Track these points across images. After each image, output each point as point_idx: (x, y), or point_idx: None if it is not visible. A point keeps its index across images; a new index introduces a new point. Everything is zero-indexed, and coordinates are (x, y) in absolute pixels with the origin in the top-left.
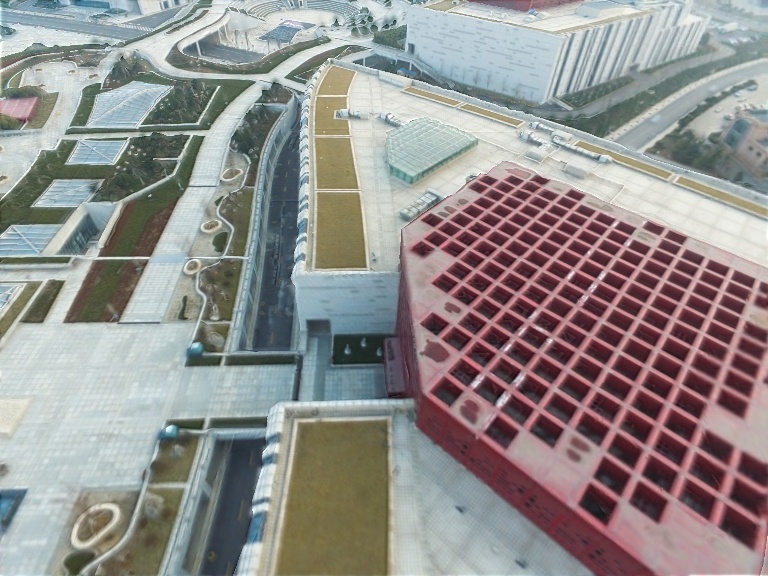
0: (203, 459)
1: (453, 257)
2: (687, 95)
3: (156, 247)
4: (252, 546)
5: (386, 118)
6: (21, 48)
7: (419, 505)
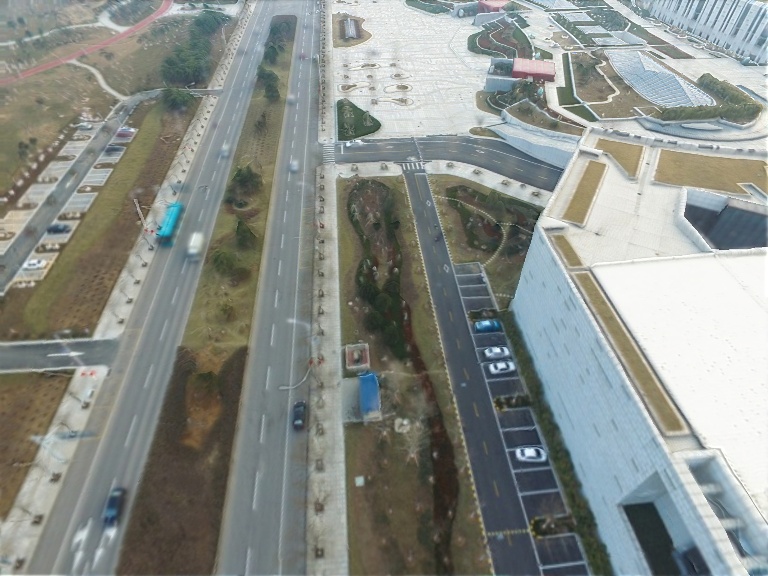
0: None
1: None
2: None
3: None
4: None
5: None
6: None
7: None
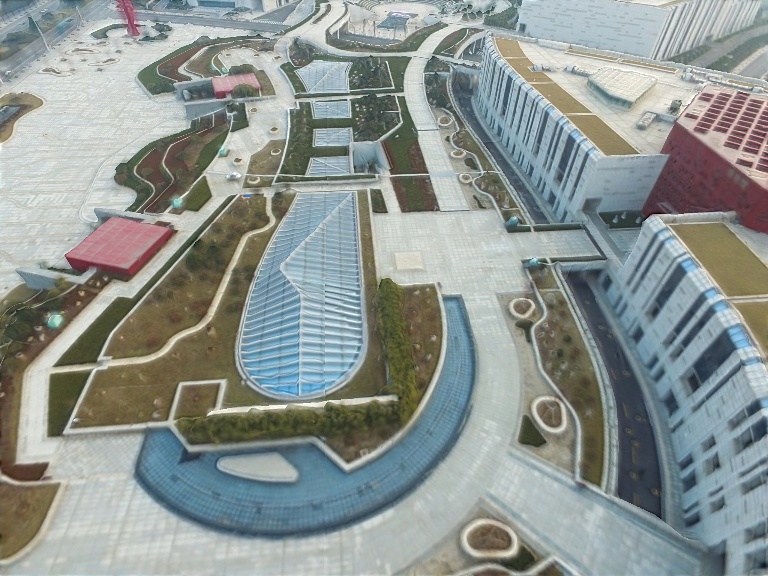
0: (562, 278)
1: (725, 133)
2: (760, 58)
3: (428, 168)
4: (698, 269)
5: (573, 70)
6: (187, 41)
7: None
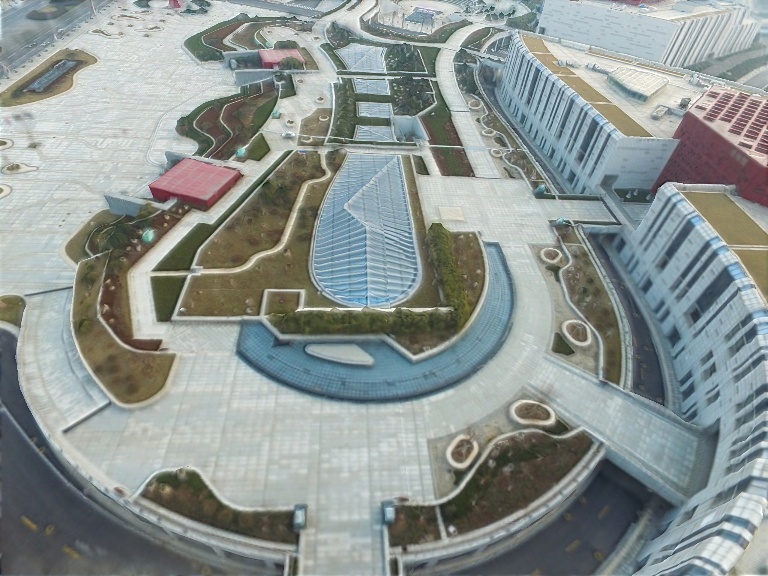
0: (583, 236)
1: (729, 123)
2: (756, 77)
3: (462, 142)
4: (705, 223)
5: (593, 67)
6: (226, 17)
7: (764, 221)
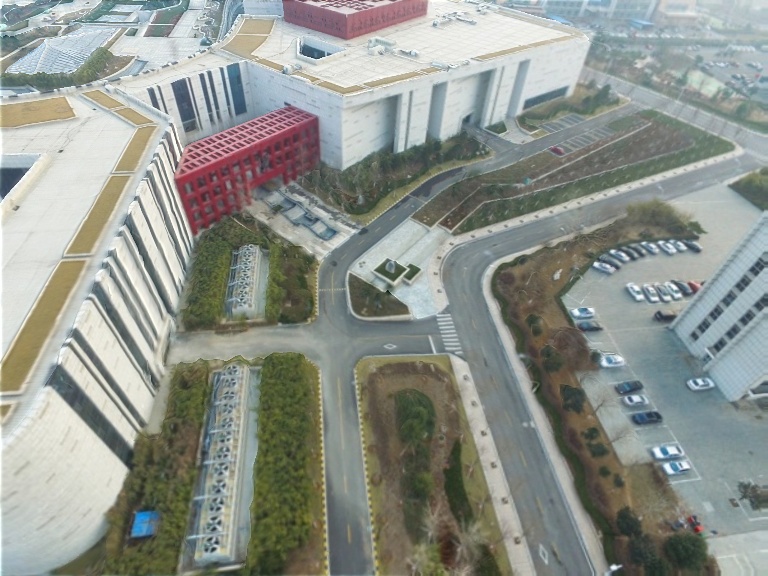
0: None
1: None
2: None
3: (178, 23)
4: None
5: None
6: None
7: None
